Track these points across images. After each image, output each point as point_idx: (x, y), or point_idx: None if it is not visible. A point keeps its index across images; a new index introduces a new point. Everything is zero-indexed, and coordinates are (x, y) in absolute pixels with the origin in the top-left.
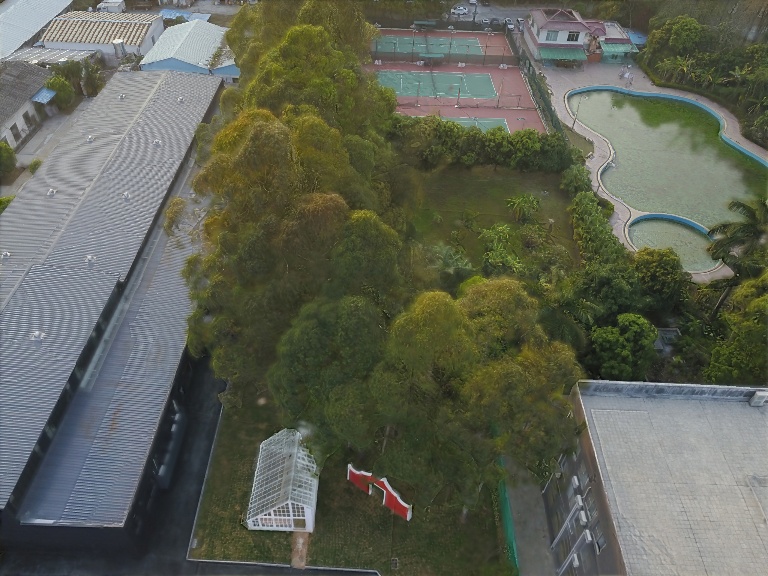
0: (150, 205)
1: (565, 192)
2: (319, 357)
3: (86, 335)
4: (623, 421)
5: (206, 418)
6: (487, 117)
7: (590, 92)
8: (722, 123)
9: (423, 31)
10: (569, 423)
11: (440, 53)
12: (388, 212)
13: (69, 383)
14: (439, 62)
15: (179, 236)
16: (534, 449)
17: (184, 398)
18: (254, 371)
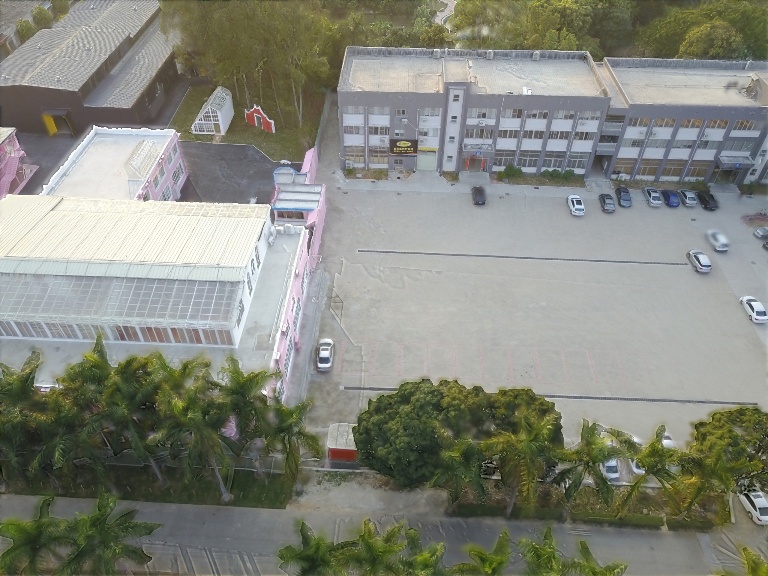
0: (148, 12)
1: None
2: (209, 0)
3: (113, 49)
4: (367, 62)
5: (175, 100)
6: None
7: None
8: None
9: None
10: (321, 35)
11: None
12: None
13: (105, 66)
14: None
15: None
16: (290, 22)
17: (164, 91)
18: (190, 36)
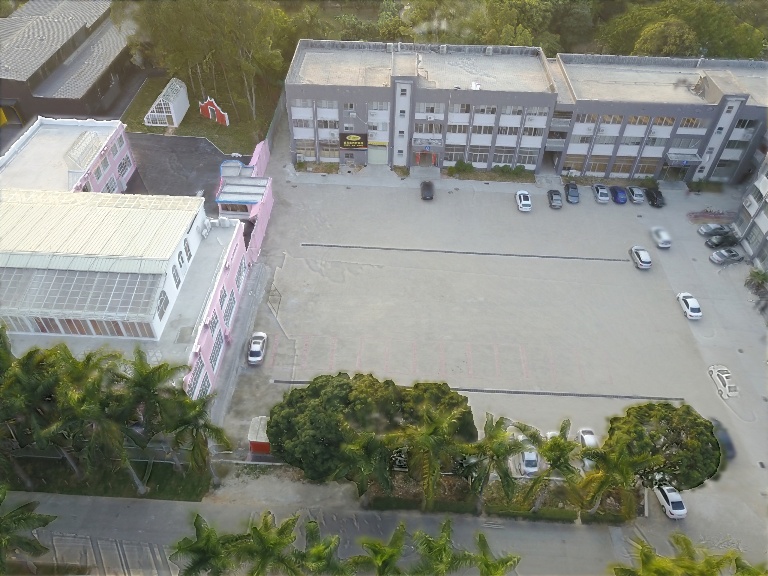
0: (108, 2)
1: None
2: None
3: (66, 39)
4: (319, 55)
5: (131, 92)
6: None
7: None
8: None
9: None
10: (270, 27)
11: None
12: None
13: (57, 56)
14: None
15: None
16: (236, 13)
17: (119, 82)
18: (140, 26)
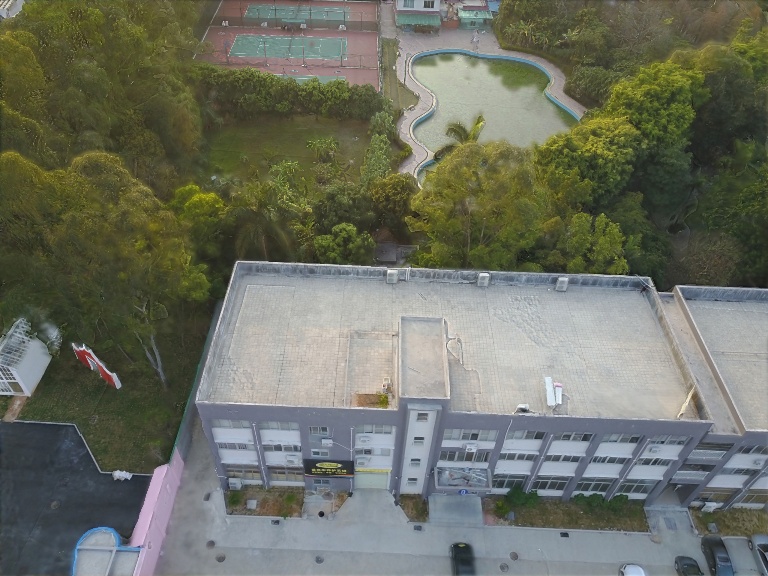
0: None
1: None
2: None
3: None
4: (270, 293)
5: None
6: (329, 75)
7: (439, 55)
8: (550, 81)
9: (299, 0)
10: (173, 277)
11: (302, 19)
12: (138, 136)
13: None
14: None
15: None
16: (96, 280)
17: None
18: None
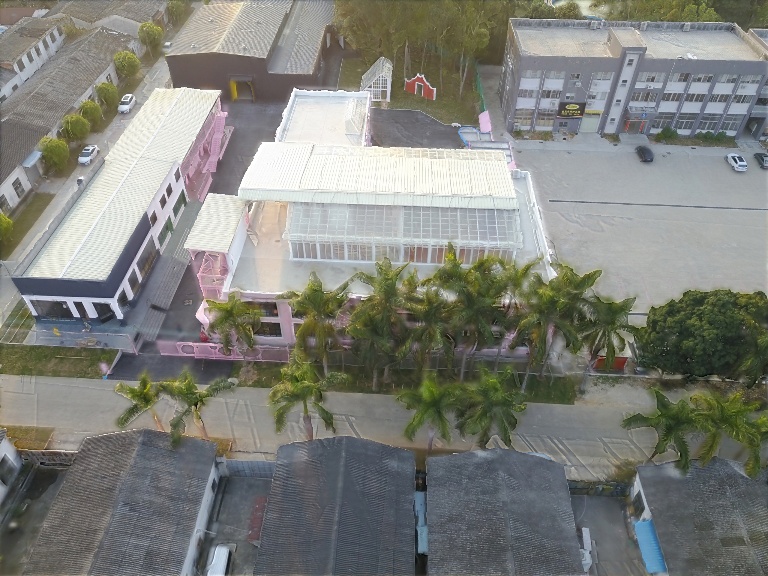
0: None
1: (528, 6)
2: None
3: (279, 22)
4: (530, 32)
5: (333, 71)
6: None
7: None
8: None
9: None
10: (499, 5)
11: None
12: None
13: (275, 38)
14: None
15: (308, 6)
16: None
17: None
18: (367, 7)
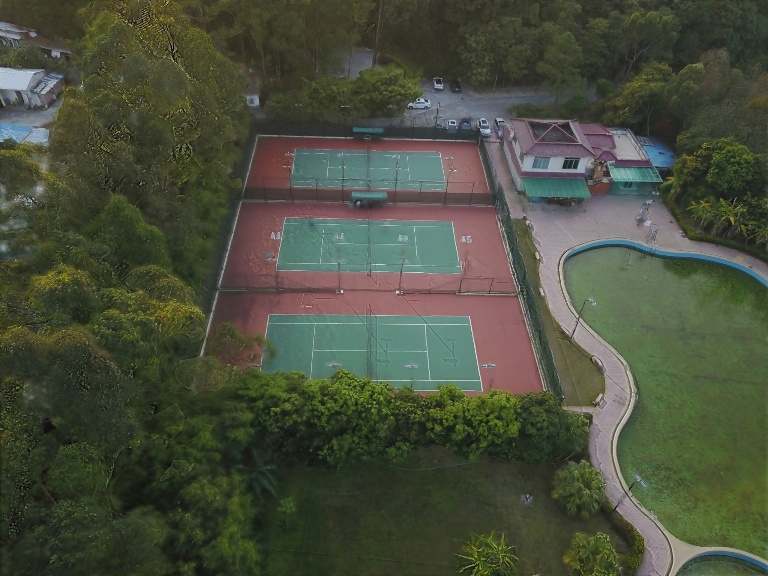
0: None
1: (560, 504)
2: None
3: None
4: None
5: None
6: (442, 314)
7: (595, 250)
8: None
9: (366, 140)
10: None
11: (382, 190)
12: None
13: None
14: (381, 201)
15: None
16: None
17: None
18: None
